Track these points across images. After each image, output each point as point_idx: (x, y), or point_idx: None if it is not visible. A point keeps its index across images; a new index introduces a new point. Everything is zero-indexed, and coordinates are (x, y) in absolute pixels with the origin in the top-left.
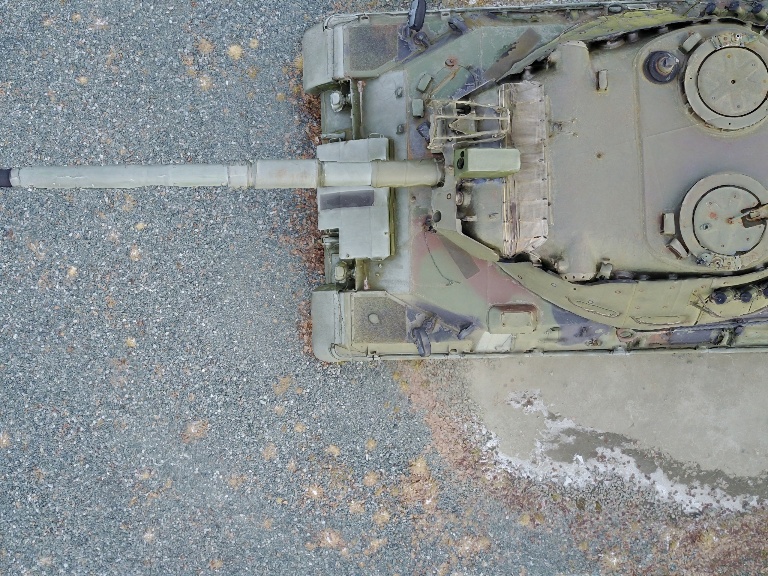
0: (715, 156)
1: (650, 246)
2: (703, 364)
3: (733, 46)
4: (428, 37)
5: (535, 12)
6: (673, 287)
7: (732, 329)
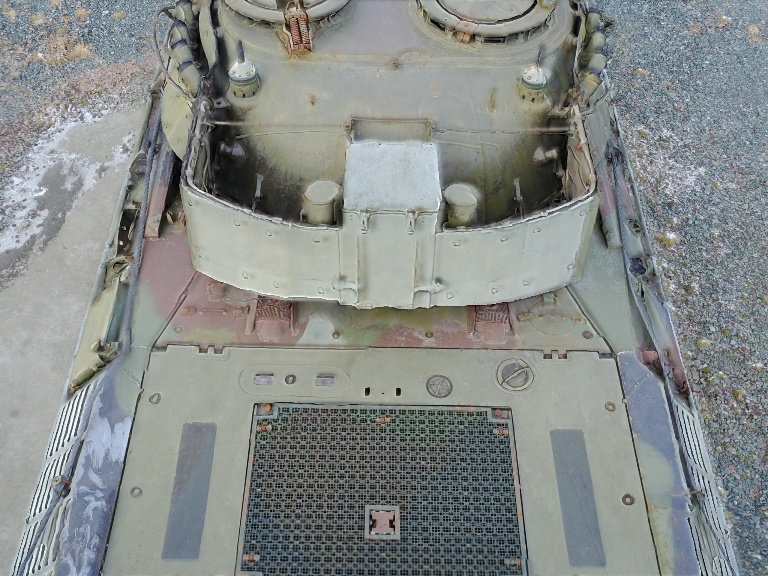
0: None
1: None
2: None
3: None
4: None
5: None
6: None
7: None
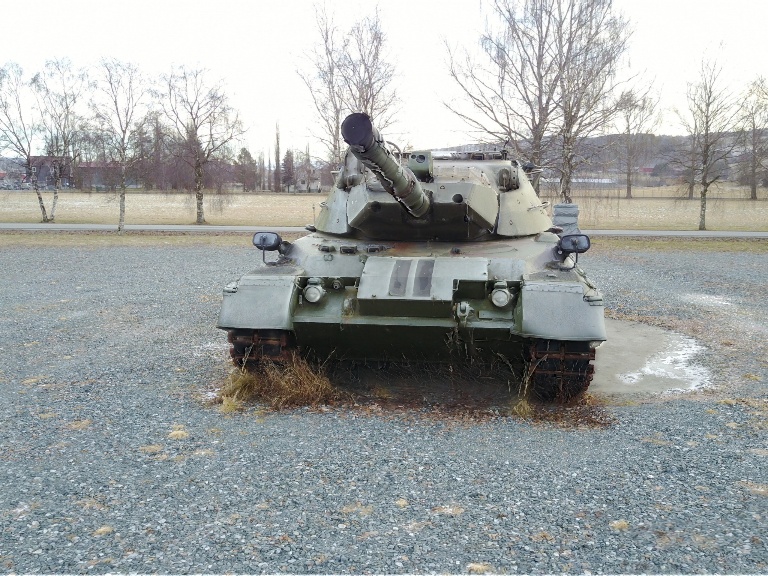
0: None
1: (493, 161)
2: None
3: None
4: None
5: None
6: None
7: None
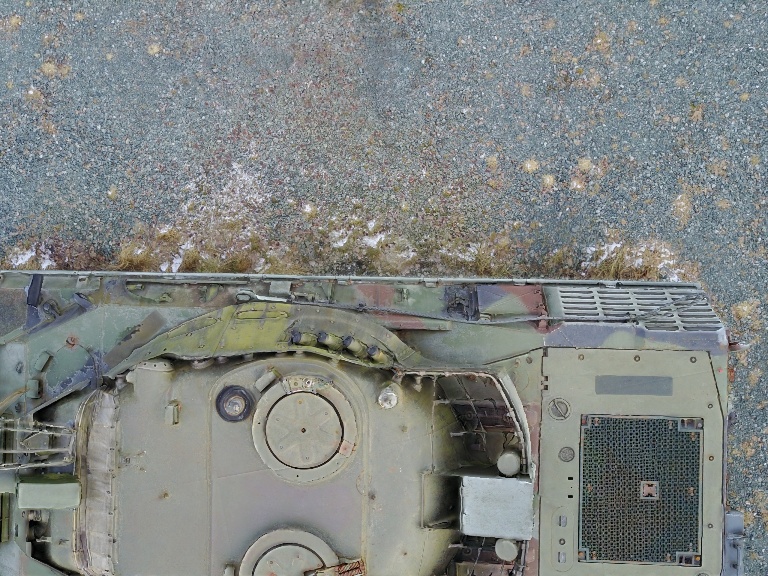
0: (288, 504)
1: None
2: None
3: (305, 391)
4: (58, 305)
5: (175, 284)
6: None
7: None
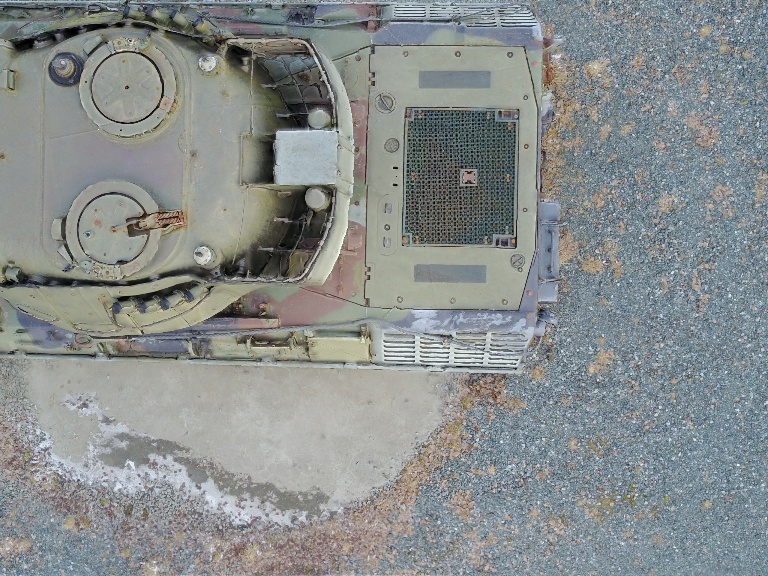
0: (115, 162)
1: (45, 251)
2: (260, 375)
3: (129, 51)
4: None
5: (36, 8)
6: (74, 294)
7: (197, 340)
